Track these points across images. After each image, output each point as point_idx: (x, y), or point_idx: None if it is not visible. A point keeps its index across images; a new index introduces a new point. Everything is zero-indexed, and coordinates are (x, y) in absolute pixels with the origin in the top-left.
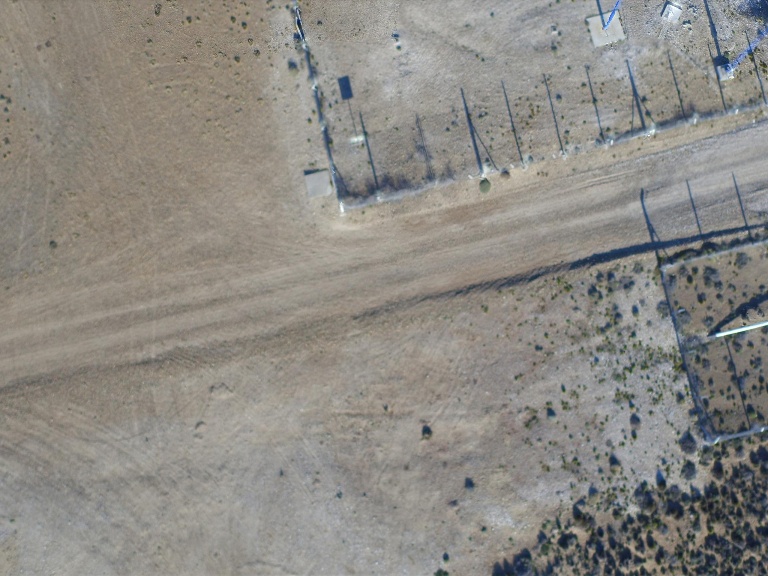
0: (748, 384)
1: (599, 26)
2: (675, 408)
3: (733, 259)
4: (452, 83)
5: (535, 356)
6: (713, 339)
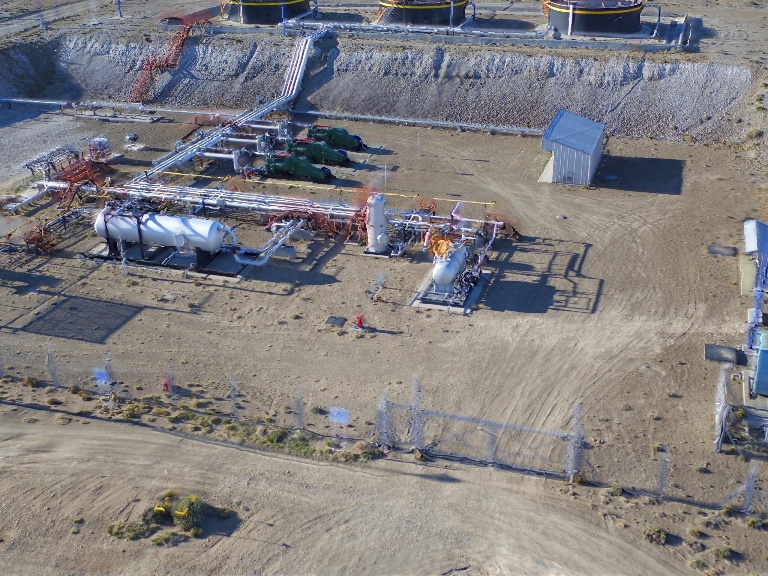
0: None
1: None
2: None
3: None
4: None
5: (30, 3)
6: None
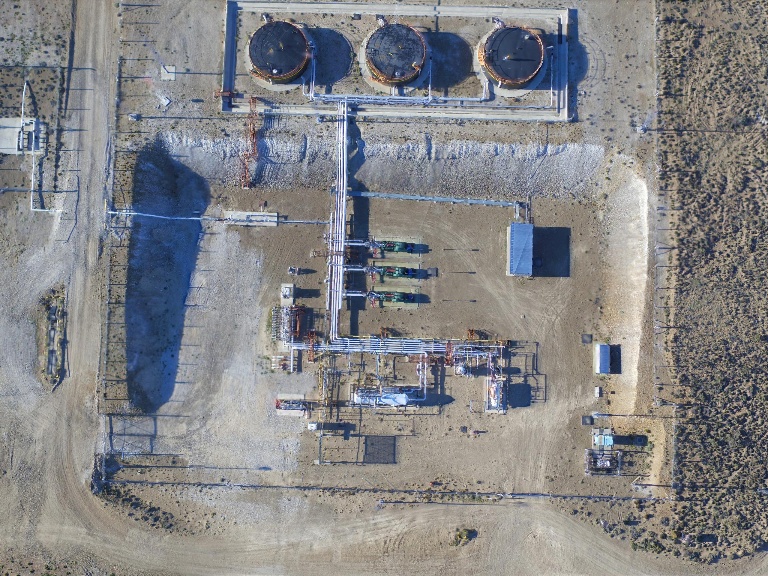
0: (3, 90)
1: (170, 70)
2: (2, 57)
3: (55, 99)
4: (166, 3)
5: (41, 7)
6: (25, 81)
